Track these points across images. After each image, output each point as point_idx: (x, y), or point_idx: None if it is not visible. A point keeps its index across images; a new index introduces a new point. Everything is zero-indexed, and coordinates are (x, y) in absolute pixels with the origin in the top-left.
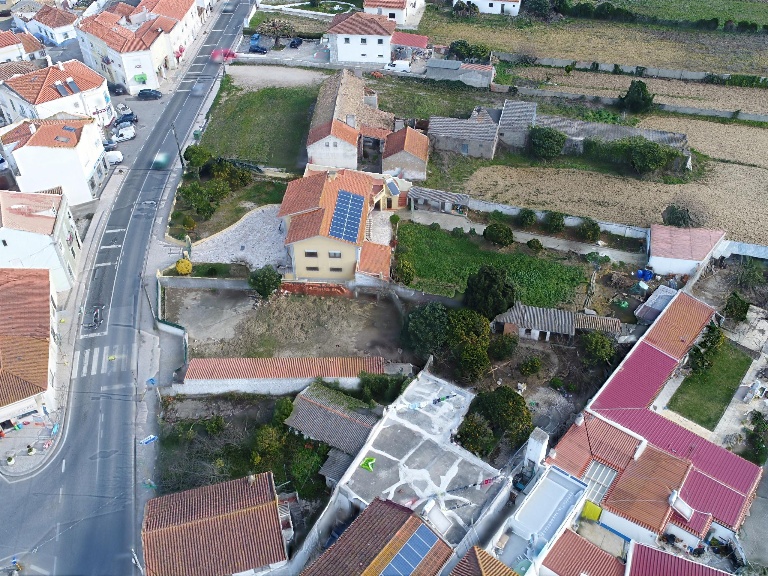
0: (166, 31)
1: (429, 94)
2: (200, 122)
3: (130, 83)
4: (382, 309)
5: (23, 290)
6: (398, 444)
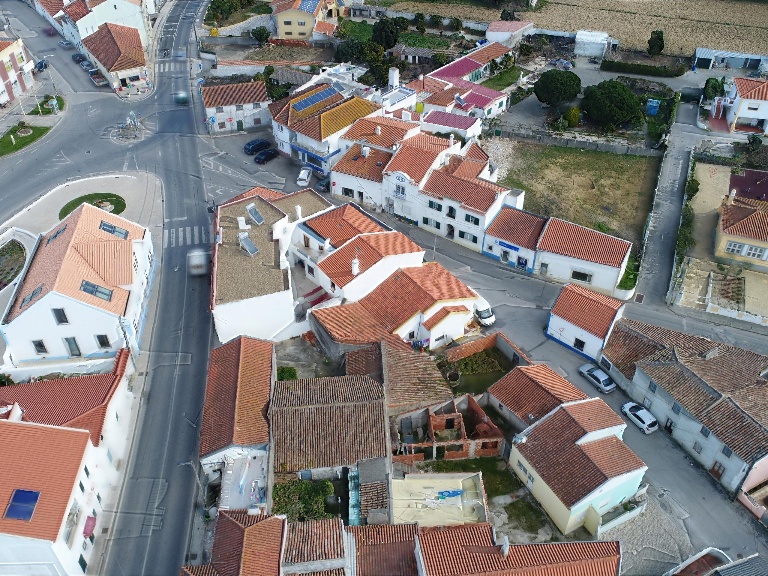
0: None
1: None
2: None
3: None
4: (327, 51)
5: (126, 33)
6: None
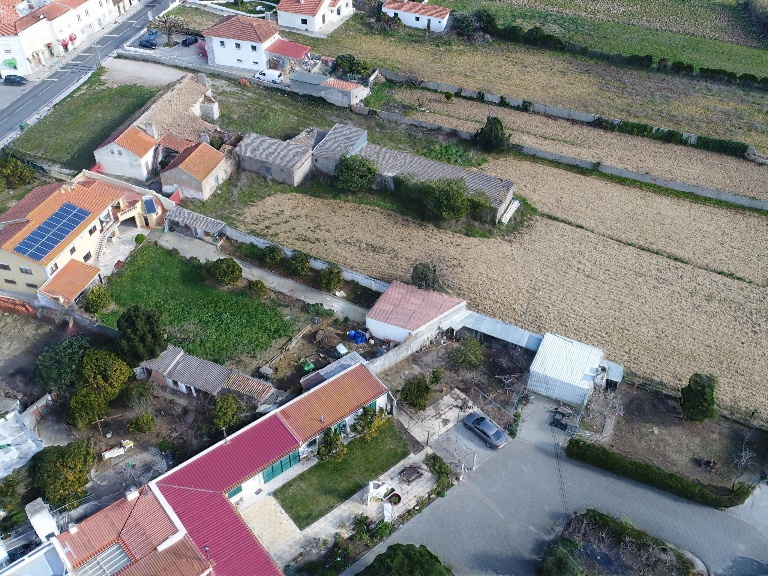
0: (50, 18)
1: (284, 108)
2: (40, 113)
3: (1, 67)
4: (55, 335)
5: None
6: None
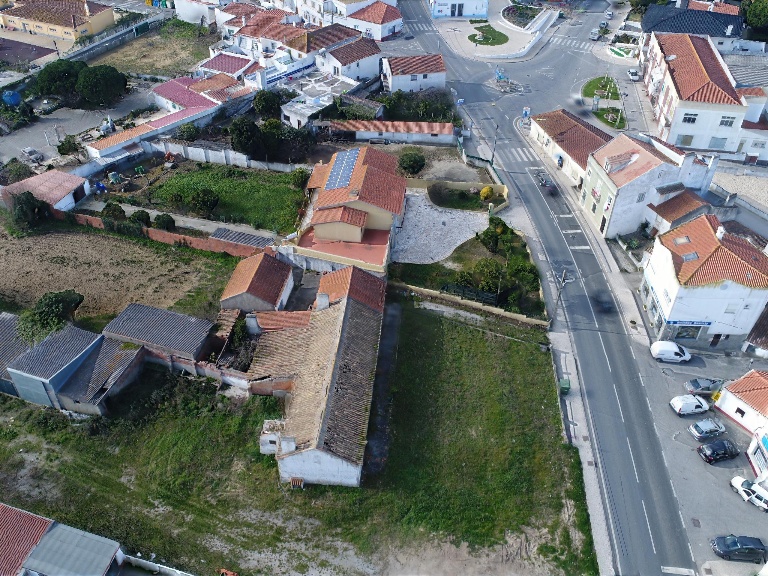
0: None
1: (146, 508)
2: (582, 438)
3: None
4: None
5: None
6: (330, 97)
